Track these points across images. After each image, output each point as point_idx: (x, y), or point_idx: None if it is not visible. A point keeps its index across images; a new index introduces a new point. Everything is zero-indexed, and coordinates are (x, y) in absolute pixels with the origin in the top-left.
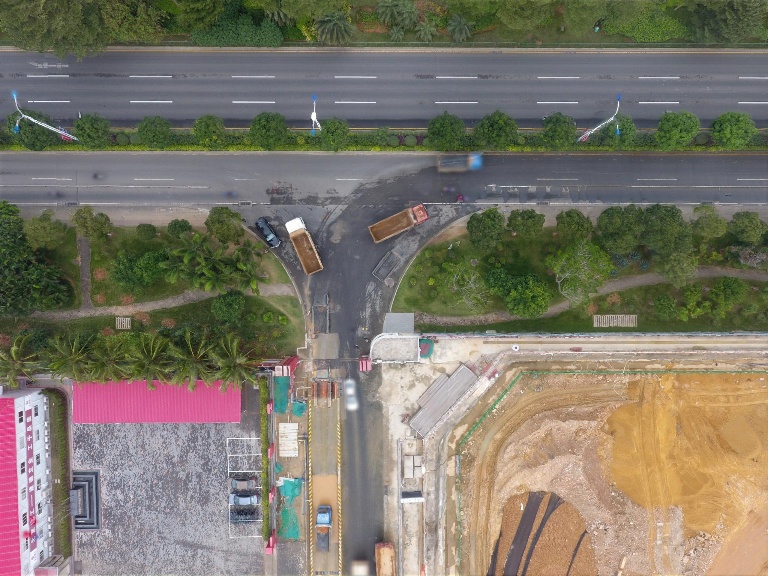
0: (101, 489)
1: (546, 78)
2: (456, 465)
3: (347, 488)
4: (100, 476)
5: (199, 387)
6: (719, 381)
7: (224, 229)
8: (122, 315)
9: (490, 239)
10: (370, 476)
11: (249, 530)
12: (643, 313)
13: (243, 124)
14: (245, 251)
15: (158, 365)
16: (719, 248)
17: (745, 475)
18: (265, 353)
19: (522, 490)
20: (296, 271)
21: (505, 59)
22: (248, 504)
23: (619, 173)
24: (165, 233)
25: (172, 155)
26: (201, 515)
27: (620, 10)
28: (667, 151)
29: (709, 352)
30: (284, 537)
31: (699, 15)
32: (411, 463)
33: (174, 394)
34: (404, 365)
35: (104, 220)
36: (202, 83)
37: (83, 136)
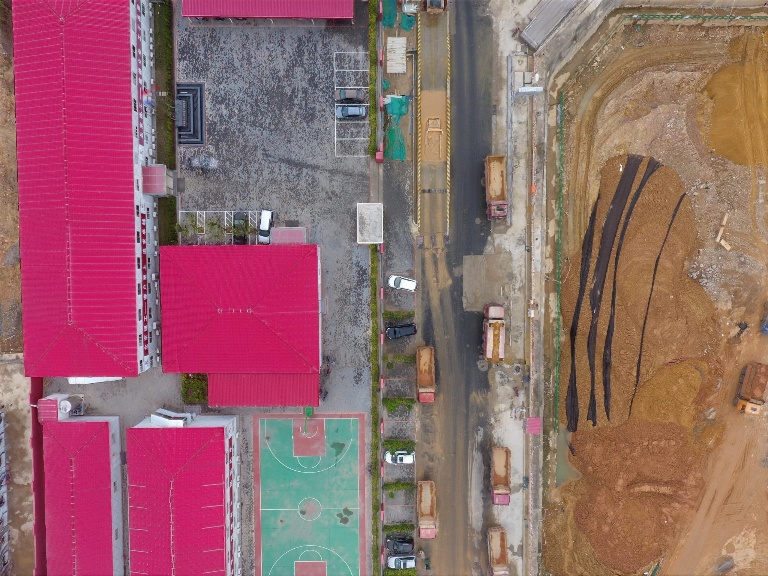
0: (205, 103)
1: None
2: (557, 115)
3: (455, 107)
4: (205, 89)
5: None
6: None
7: None
8: None
9: None
10: (479, 94)
11: (355, 149)
12: None
13: None
14: None
15: None
16: None
17: None
18: None
19: (622, 149)
20: None
21: None
22: (357, 114)
23: None
24: None
25: None
26: (307, 132)
27: None
28: None
29: None
30: (390, 158)
31: None
32: (521, 79)
33: None
34: None
35: None
36: None
37: None
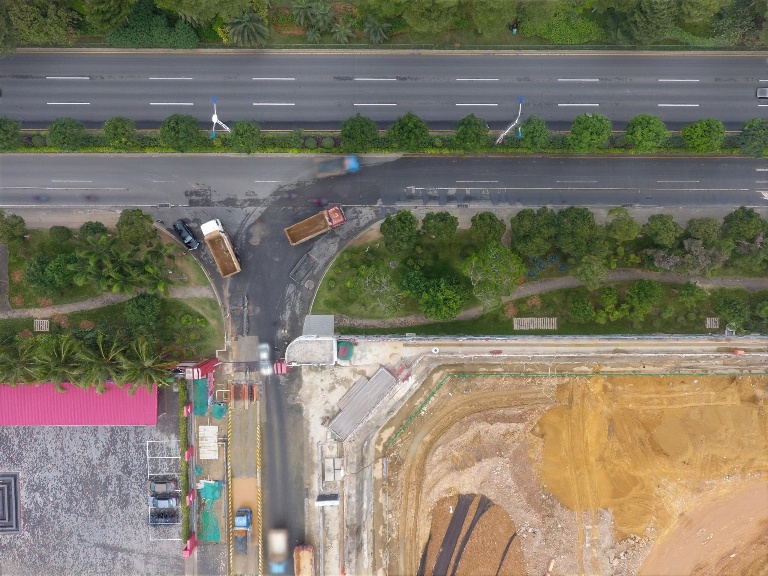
0: (20, 492)
1: (465, 80)
2: (383, 468)
3: (268, 491)
4: (19, 479)
5: (115, 390)
6: (653, 383)
7: (132, 231)
8: (40, 317)
9: (400, 242)
10: (291, 479)
11: (169, 533)
12: (563, 316)
13: None
14: (156, 253)
15: (67, 368)
16: (637, 251)
17: (676, 478)
18: (183, 355)
19: (451, 493)
20: (215, 273)
21: (424, 61)
22: (167, 507)
23: (539, 175)
24: None
25: (90, 157)
26: (121, 518)
27: (531, 12)
28: (586, 153)
29: (629, 355)
30: (205, 540)
31: (613, 17)
32: (331, 466)
33: (90, 397)
34: (324, 368)
35: (15, 222)
36: (119, 85)
37: None
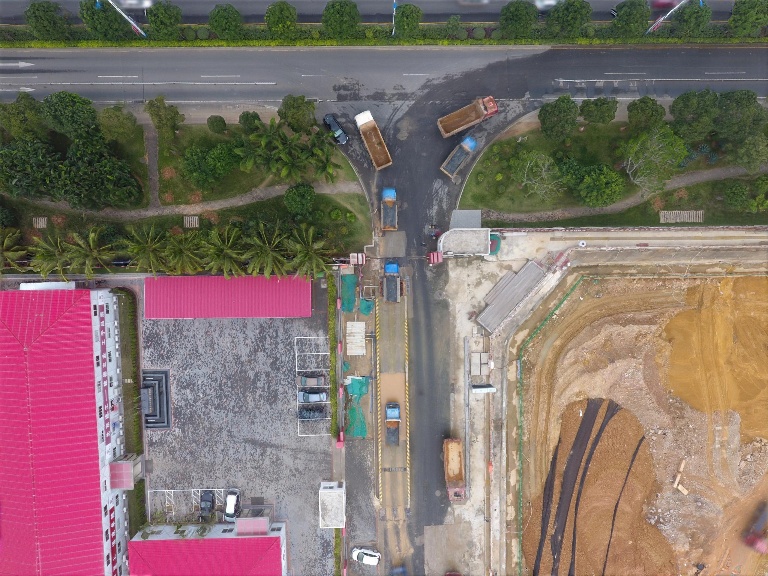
0: (171, 388)
1: None
2: (517, 370)
3: (414, 386)
4: (170, 375)
5: (269, 282)
6: None
7: (299, 114)
8: (190, 214)
9: (565, 123)
10: (437, 374)
11: (317, 428)
12: (710, 208)
13: (309, 19)
14: (318, 139)
15: (234, 253)
16: None
17: None
18: None
19: (581, 396)
20: (363, 169)
21: None
22: (317, 401)
23: (687, 67)
24: (232, 130)
25: (238, 51)
26: (270, 414)
27: None
28: (736, 43)
29: None
30: (352, 435)
31: None
32: (478, 360)
33: (245, 289)
34: (471, 263)
35: (176, 110)
36: None
37: (155, 23)
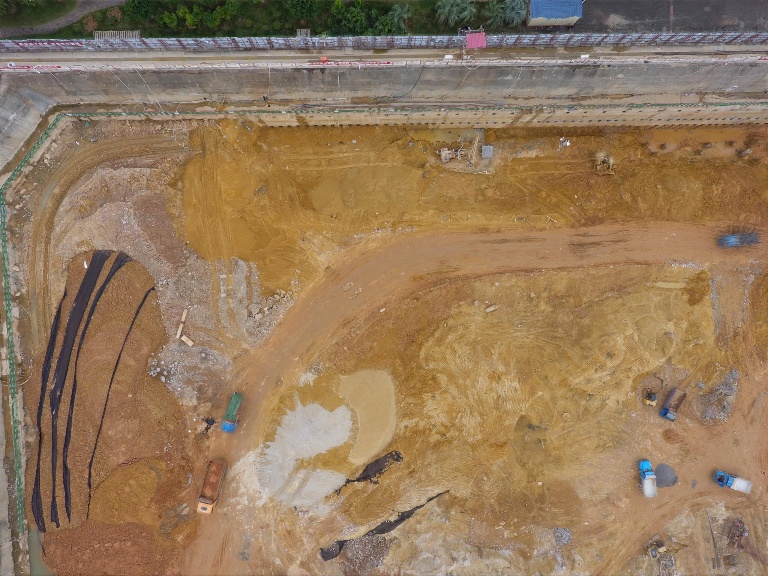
0: None
1: None
2: (2, 215)
3: None
4: None
5: None
6: (310, 144)
7: None
8: None
9: None
10: None
11: None
12: (146, 28)
13: None
14: None
15: None
16: None
17: (321, 231)
18: None
19: (82, 246)
20: None
21: None
22: None
23: None
24: None
25: None
26: None
27: None
28: None
29: (214, 67)
30: None
31: None
32: None
33: None
34: None
35: None
36: None
37: None
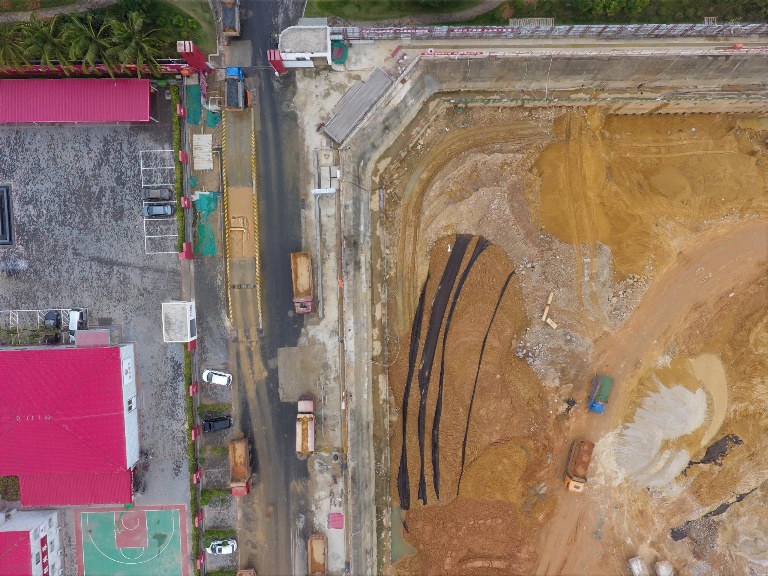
0: (13, 204)
1: None
2: (380, 199)
3: (263, 202)
4: (11, 190)
5: (106, 86)
6: (650, 132)
7: None
8: (28, 21)
9: None
10: (287, 189)
11: (165, 246)
12: (560, 16)
13: None
14: None
15: None
16: None
17: (674, 217)
18: (175, 56)
19: (449, 230)
20: None
21: None
22: (162, 213)
23: None
24: None
25: None
26: (116, 231)
27: None
28: None
29: (627, 54)
30: (201, 253)
31: None
32: (327, 174)
33: (81, 93)
34: (318, 73)
35: None
36: None
37: None
